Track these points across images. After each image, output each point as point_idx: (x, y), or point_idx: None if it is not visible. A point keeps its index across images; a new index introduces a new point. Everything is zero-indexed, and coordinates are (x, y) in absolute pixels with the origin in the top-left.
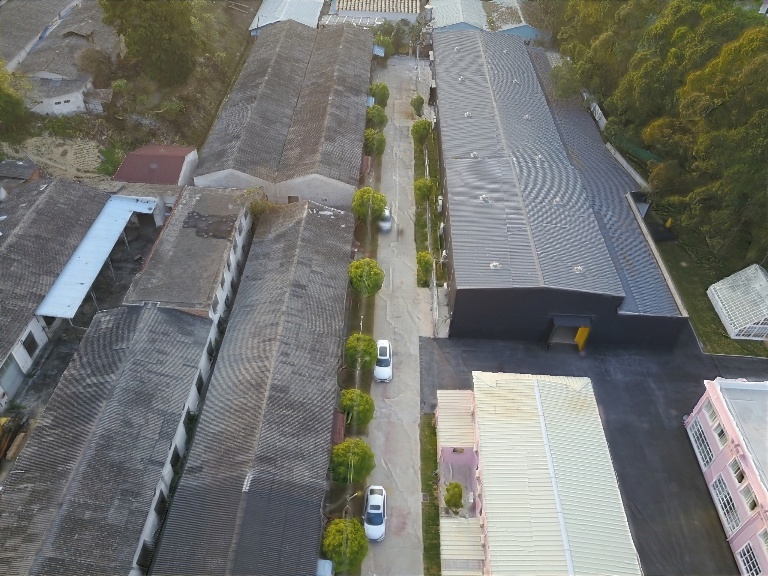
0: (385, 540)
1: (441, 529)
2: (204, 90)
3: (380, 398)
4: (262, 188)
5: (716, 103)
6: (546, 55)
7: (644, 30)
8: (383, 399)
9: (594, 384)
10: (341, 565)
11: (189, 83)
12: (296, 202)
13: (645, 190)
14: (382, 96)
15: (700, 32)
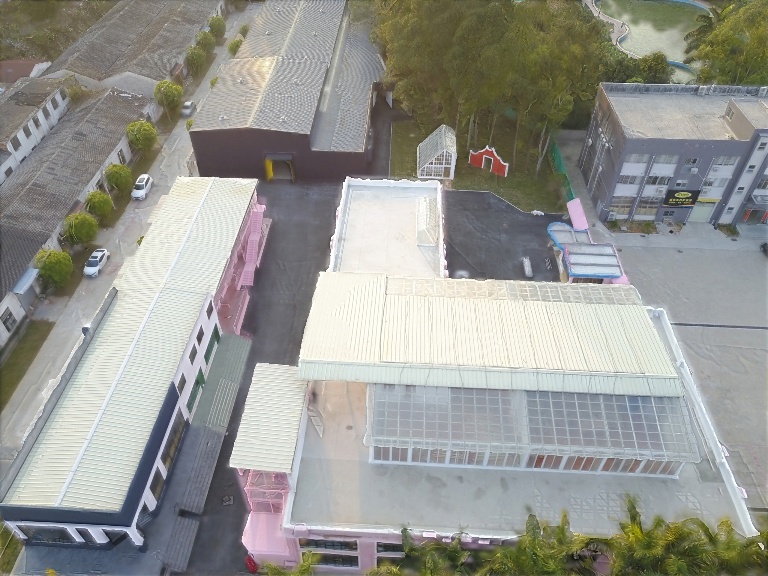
0: (98, 277)
1: (125, 261)
2: (78, 26)
3: (132, 209)
4: (74, 76)
5: None
6: None
7: None
8: (134, 209)
9: (292, 201)
10: (43, 269)
11: (63, 20)
12: None
13: (381, 79)
14: (217, 26)
15: None
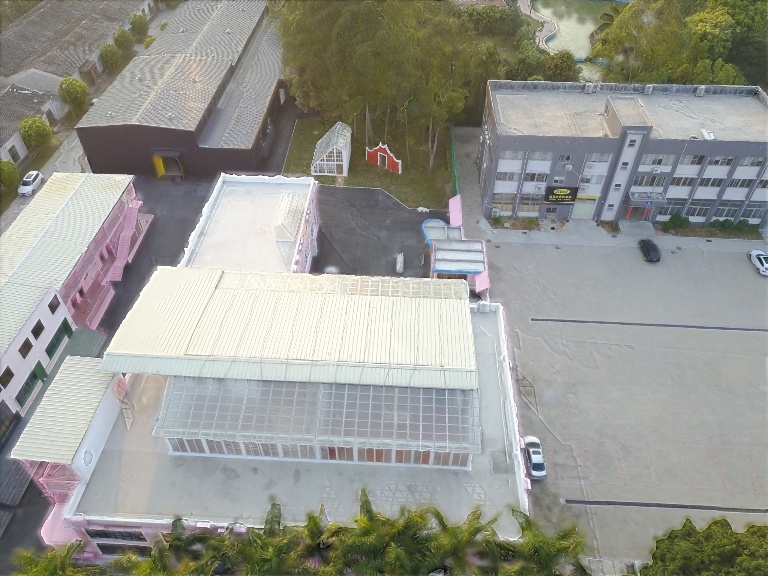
0: None
1: None
2: (1, 23)
3: (17, 205)
4: None
5: None
6: None
7: None
8: (19, 205)
9: (179, 197)
10: None
11: None
12: None
13: None
14: (139, 24)
15: None
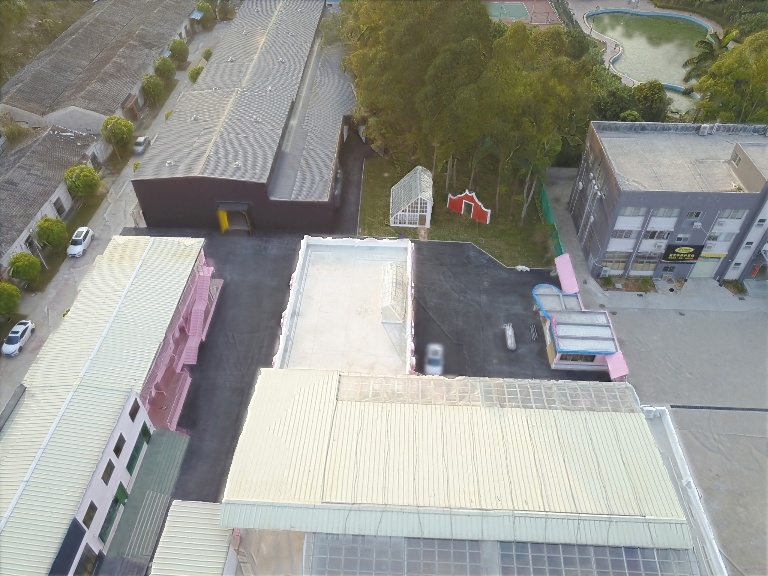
0: (19, 355)
1: (47, 340)
2: (28, 50)
3: (67, 268)
4: (9, 113)
5: (362, 28)
6: None
7: None
8: (69, 269)
9: (248, 257)
10: None
11: (12, 44)
12: None
13: (351, 112)
14: (179, 50)
15: None
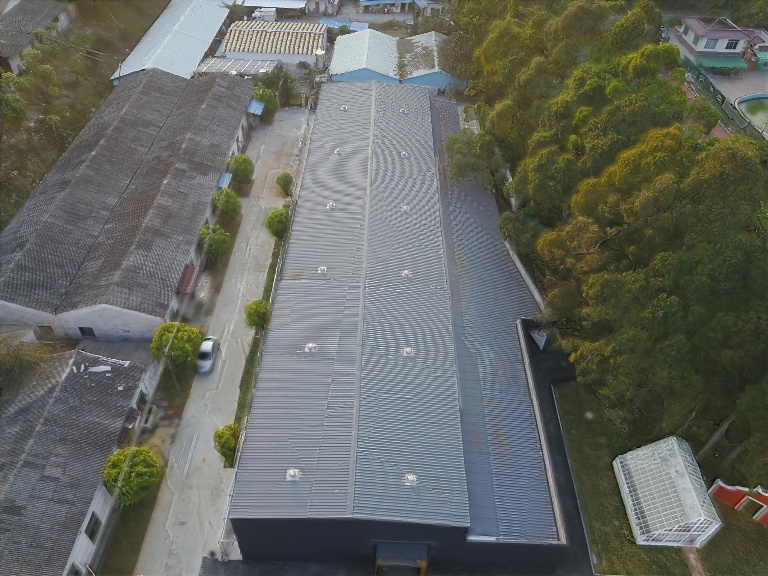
0: None
1: None
2: (26, 165)
3: None
4: (5, 341)
5: (609, 233)
6: (457, 110)
7: (548, 101)
8: None
9: None
10: None
11: (3, 158)
12: (62, 353)
13: (538, 320)
14: (242, 172)
15: (603, 119)
